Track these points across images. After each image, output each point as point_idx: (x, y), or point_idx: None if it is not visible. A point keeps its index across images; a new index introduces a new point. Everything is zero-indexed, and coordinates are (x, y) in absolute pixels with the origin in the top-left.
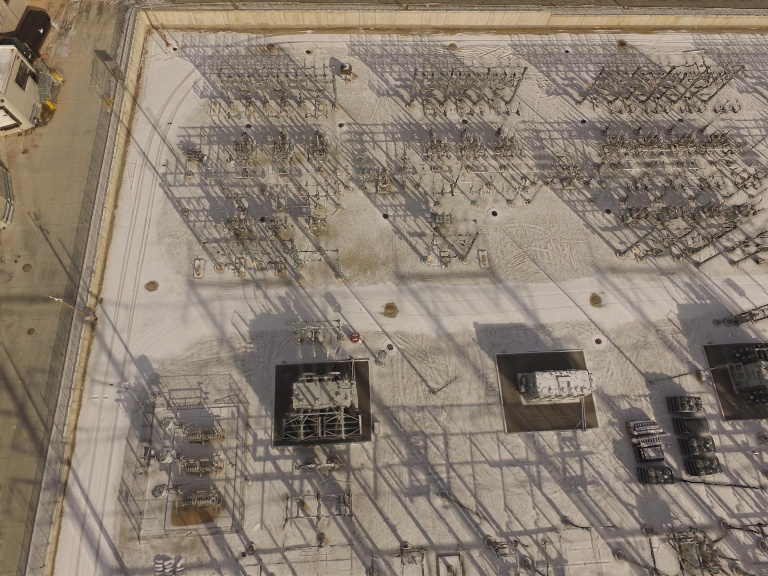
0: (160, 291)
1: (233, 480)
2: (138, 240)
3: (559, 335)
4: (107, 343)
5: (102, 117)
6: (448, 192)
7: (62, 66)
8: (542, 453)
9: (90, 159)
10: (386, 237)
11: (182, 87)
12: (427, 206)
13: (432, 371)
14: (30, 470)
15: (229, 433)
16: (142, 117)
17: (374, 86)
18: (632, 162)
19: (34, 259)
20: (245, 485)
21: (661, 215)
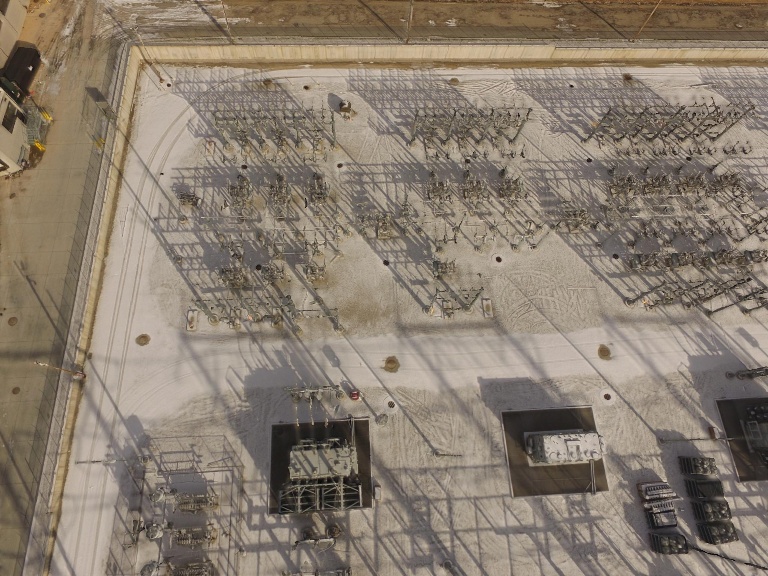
0: (152, 345)
1: (227, 551)
2: (129, 290)
3: (567, 390)
4: (96, 402)
5: (93, 159)
6: (451, 239)
7: (52, 104)
8: (550, 519)
9: (80, 204)
10: (387, 285)
11: (176, 125)
12: (429, 252)
13: (435, 430)
14: (13, 543)
15: (223, 500)
16: (134, 158)
17: (374, 124)
18: (640, 203)
19: (20, 312)
20: (239, 557)
21: (670, 261)
